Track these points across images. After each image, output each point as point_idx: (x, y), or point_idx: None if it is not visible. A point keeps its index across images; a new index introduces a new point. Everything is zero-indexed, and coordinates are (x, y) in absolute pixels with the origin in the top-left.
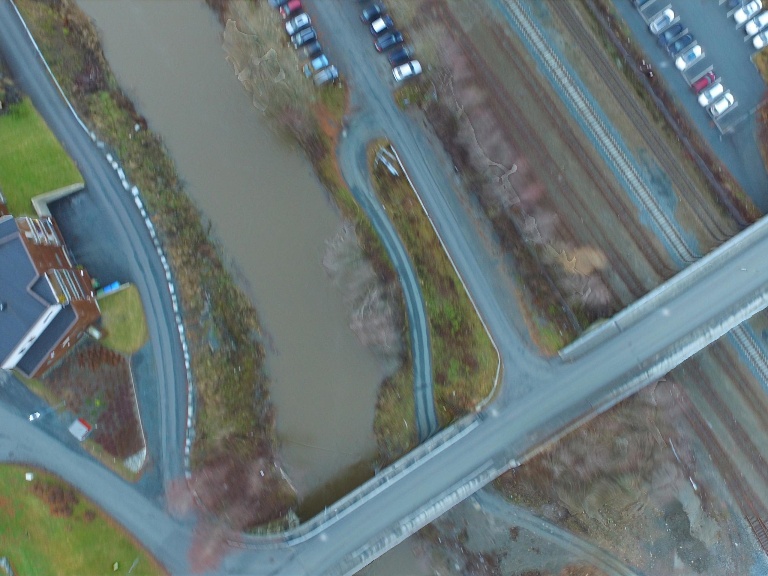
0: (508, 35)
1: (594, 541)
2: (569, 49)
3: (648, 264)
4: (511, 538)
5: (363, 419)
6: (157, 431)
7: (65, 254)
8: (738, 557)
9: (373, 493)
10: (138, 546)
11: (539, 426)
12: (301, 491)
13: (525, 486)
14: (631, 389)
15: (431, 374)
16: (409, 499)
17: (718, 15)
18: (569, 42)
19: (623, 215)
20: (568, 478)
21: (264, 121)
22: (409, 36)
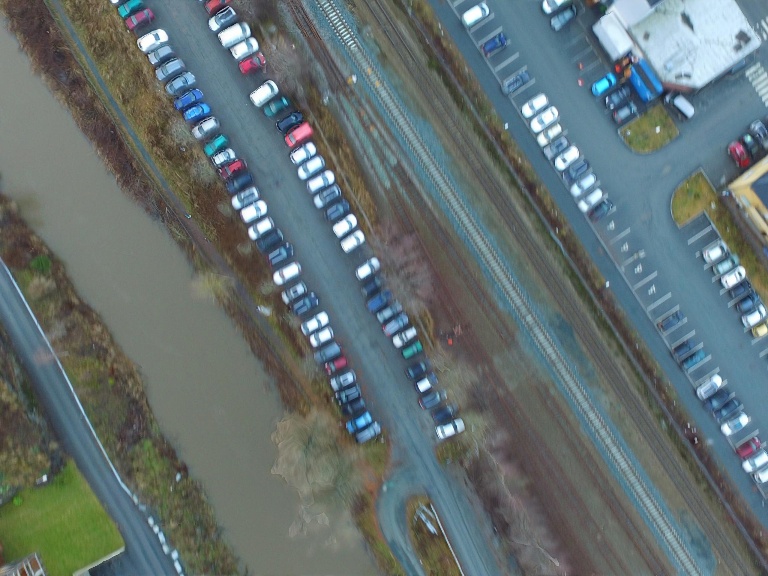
0: (553, 394)
1: None
2: (614, 409)
3: None
4: None
5: None
6: None
7: None
8: None
9: None
10: None
11: None
12: None
13: None
14: None
15: None
16: None
17: (766, 380)
18: (614, 402)
19: (661, 575)
20: None
21: None
22: (453, 393)
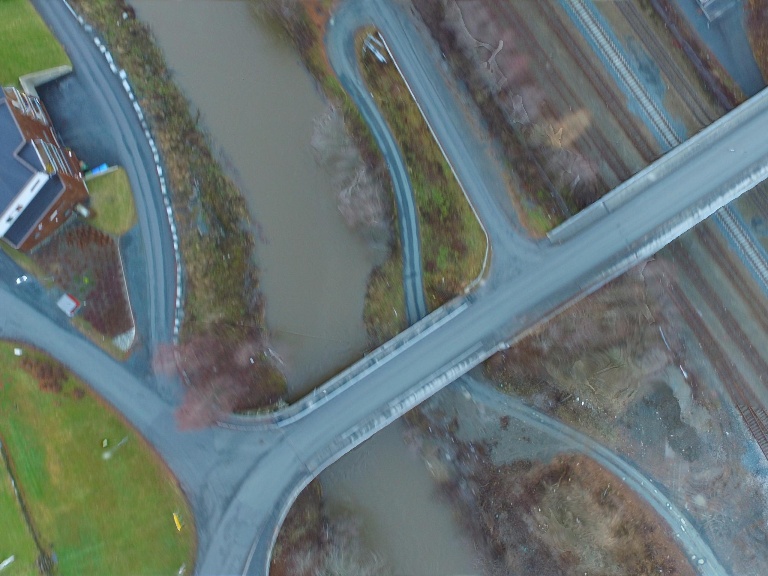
0: None
1: (585, 430)
2: None
3: (637, 152)
4: (502, 427)
5: (353, 309)
6: (146, 312)
7: (53, 136)
8: (729, 446)
9: (362, 374)
10: (127, 425)
11: (528, 309)
12: (291, 380)
13: (515, 370)
14: (620, 270)
15: (420, 262)
16: (398, 381)
17: None
18: None
19: (611, 103)
20: (557, 354)
21: (251, 6)
22: None
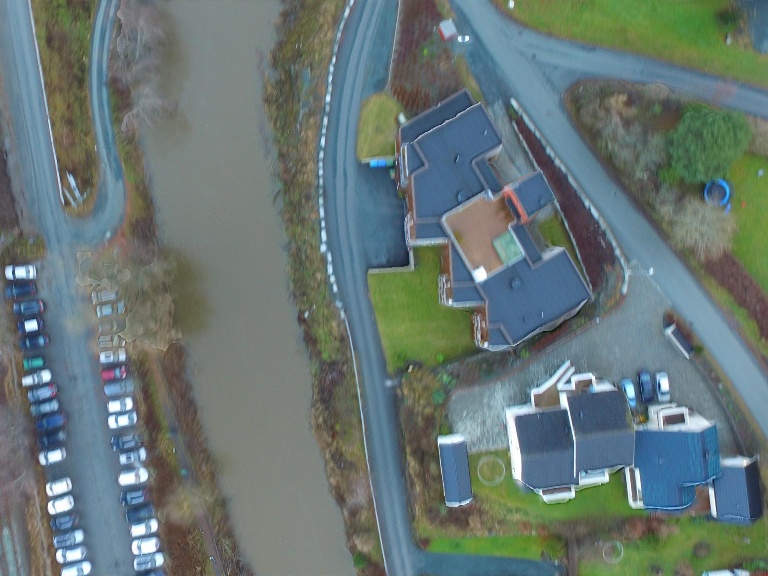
0: None
1: None
2: None
3: None
4: None
5: None
6: (387, 7)
7: None
8: None
9: None
10: None
11: None
12: None
13: None
14: None
15: None
16: None
17: None
18: None
19: None
20: None
21: (178, 272)
22: (8, 306)
